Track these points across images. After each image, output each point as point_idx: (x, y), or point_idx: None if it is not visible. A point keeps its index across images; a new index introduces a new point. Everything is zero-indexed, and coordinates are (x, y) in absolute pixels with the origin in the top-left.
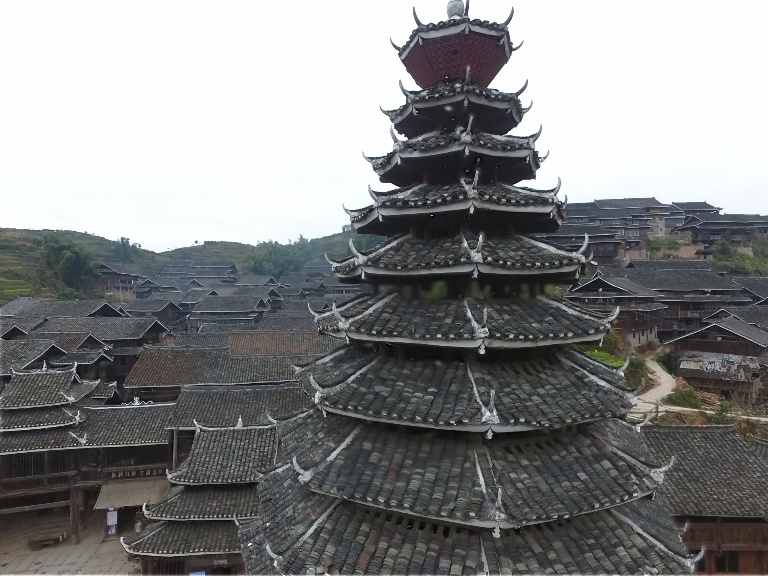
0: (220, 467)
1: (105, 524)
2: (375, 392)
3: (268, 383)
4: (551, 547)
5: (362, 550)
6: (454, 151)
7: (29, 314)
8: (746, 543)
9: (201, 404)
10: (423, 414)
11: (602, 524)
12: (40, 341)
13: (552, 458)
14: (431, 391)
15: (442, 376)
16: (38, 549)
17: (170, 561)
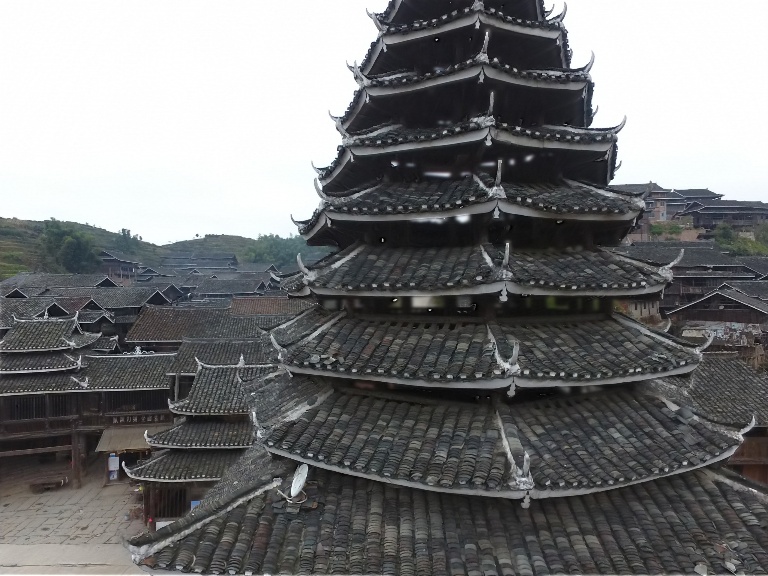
0: (222, 400)
1: (107, 469)
2: (380, 200)
3: None
4: (558, 337)
5: (367, 344)
6: None
7: None
8: (750, 457)
9: (203, 354)
10: (429, 204)
11: (609, 328)
12: (42, 299)
13: (559, 260)
14: (437, 193)
15: (447, 186)
16: (40, 492)
17: (172, 489)
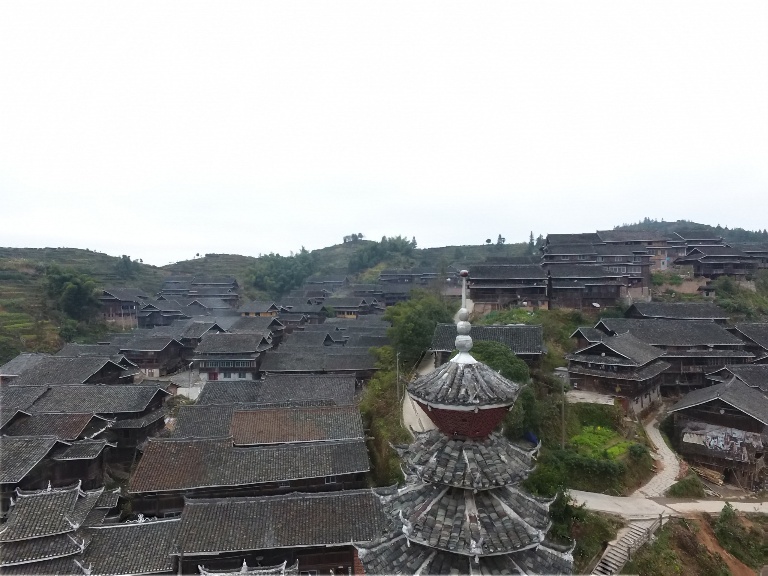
0: None
1: None
2: None
3: (271, 483)
4: None
5: None
6: (464, 554)
7: (32, 374)
8: None
9: (205, 521)
10: None
11: None
12: (44, 437)
13: None
14: None
15: None
16: None
17: None
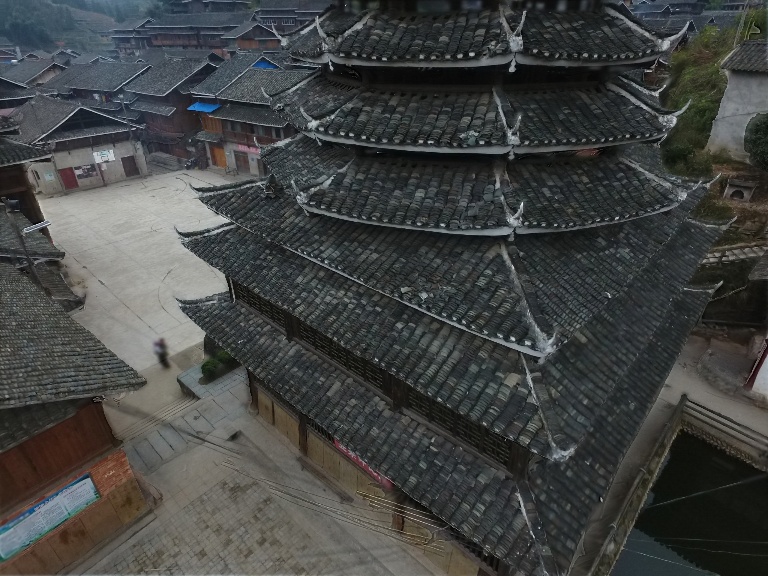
0: None
1: None
2: None
3: None
4: (406, 105)
5: None
6: None
7: None
8: None
9: None
10: None
11: (472, 101)
12: None
13: (433, 25)
14: None
15: None
16: None
17: None
